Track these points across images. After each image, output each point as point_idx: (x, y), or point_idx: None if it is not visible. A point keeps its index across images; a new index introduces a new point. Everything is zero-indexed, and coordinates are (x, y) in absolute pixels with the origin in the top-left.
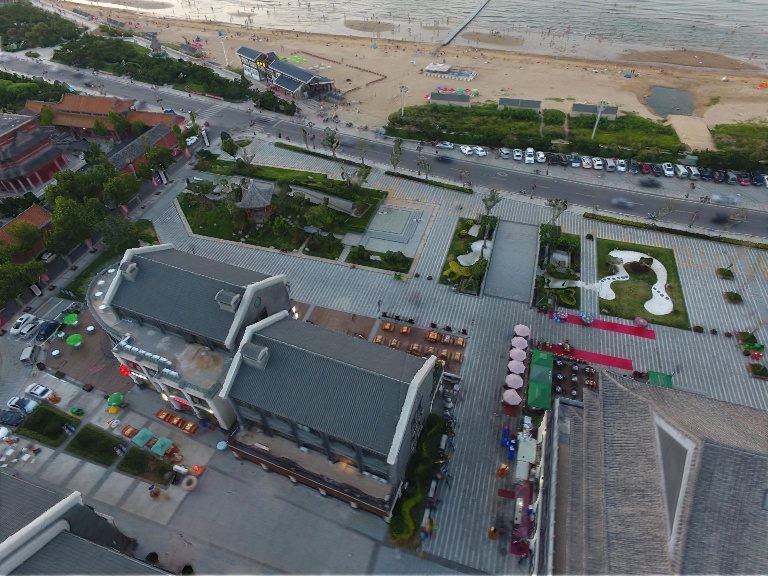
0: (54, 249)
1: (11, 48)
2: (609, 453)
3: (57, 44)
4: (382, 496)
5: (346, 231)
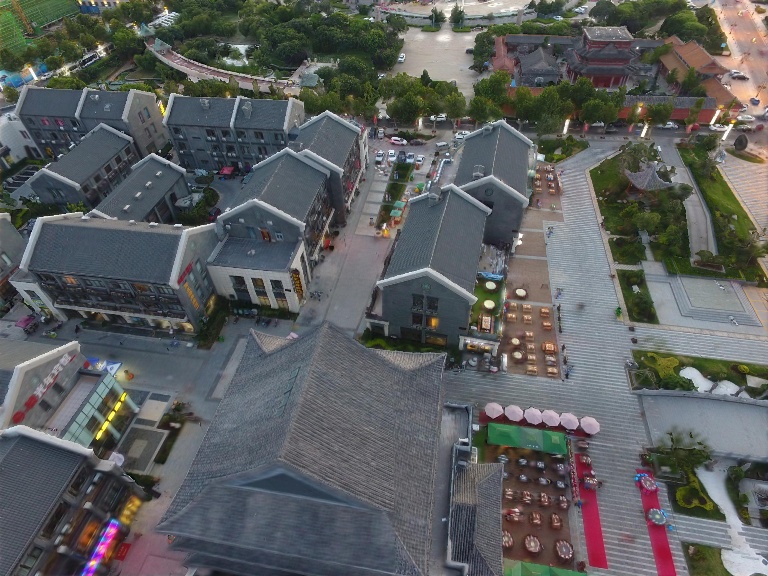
0: (518, 113)
1: None
2: None
3: None
4: (376, 312)
5: (662, 261)
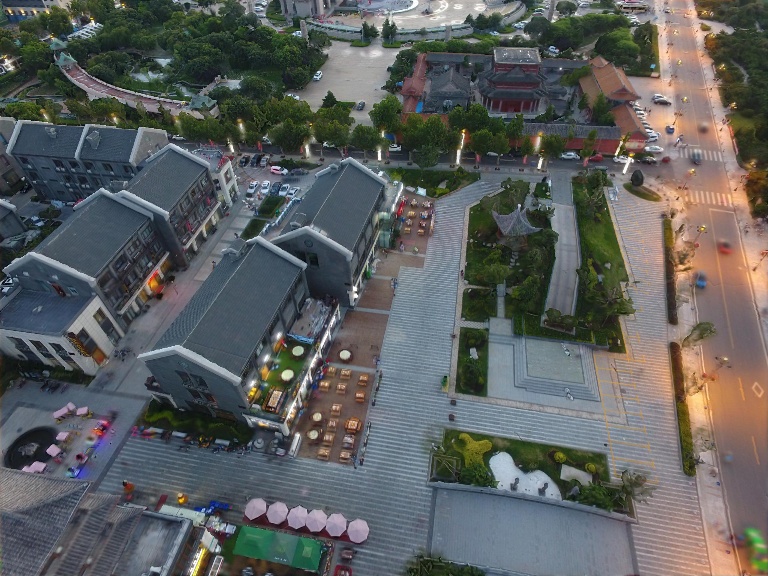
0: None
1: (692, 14)
2: (2, 473)
3: (743, 27)
4: None
5: (512, 318)
